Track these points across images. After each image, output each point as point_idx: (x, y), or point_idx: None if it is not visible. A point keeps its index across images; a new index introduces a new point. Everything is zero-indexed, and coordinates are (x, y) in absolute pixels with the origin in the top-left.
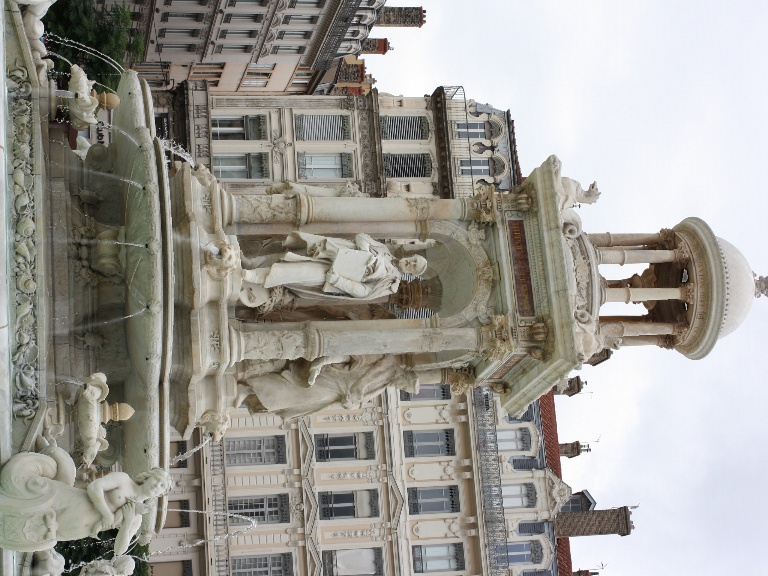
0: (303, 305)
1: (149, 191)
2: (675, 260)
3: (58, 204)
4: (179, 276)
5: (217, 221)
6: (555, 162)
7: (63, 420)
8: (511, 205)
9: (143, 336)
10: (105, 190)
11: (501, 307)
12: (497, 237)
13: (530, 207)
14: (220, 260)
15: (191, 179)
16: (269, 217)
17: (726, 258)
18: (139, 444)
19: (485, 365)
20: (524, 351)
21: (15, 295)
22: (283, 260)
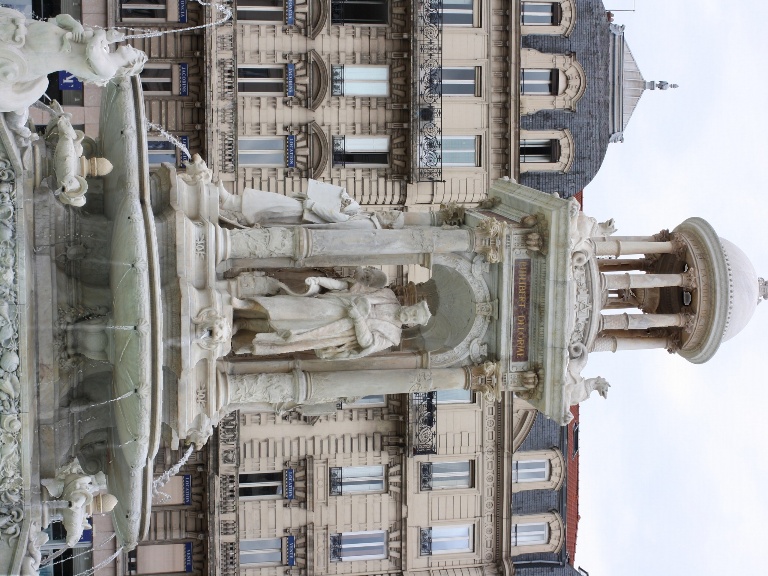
0: None
1: None
2: (656, 239)
3: None
4: None
5: None
6: None
7: (39, 151)
8: None
9: (117, 120)
10: None
11: None
12: (469, 217)
13: (493, 201)
14: (193, 165)
15: None
16: (244, 218)
17: None
18: (123, 229)
19: (500, 322)
20: (522, 246)
21: None
22: None
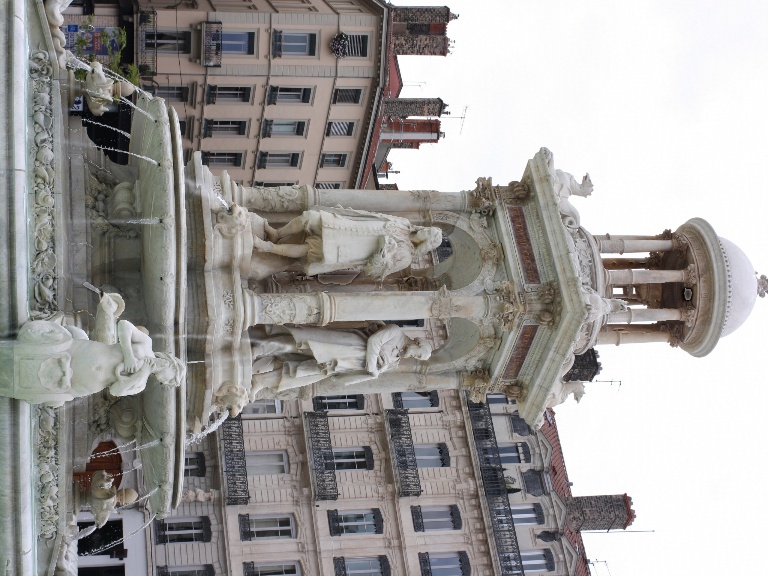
0: None
1: (164, 490)
2: None
3: (80, 410)
4: (190, 406)
5: (236, 341)
6: (588, 319)
7: None
8: (533, 317)
9: None
10: None
11: (490, 362)
12: (508, 331)
13: None
14: None
15: None
16: None
17: None
18: None
19: None
20: None
21: (40, 521)
22: (291, 376)
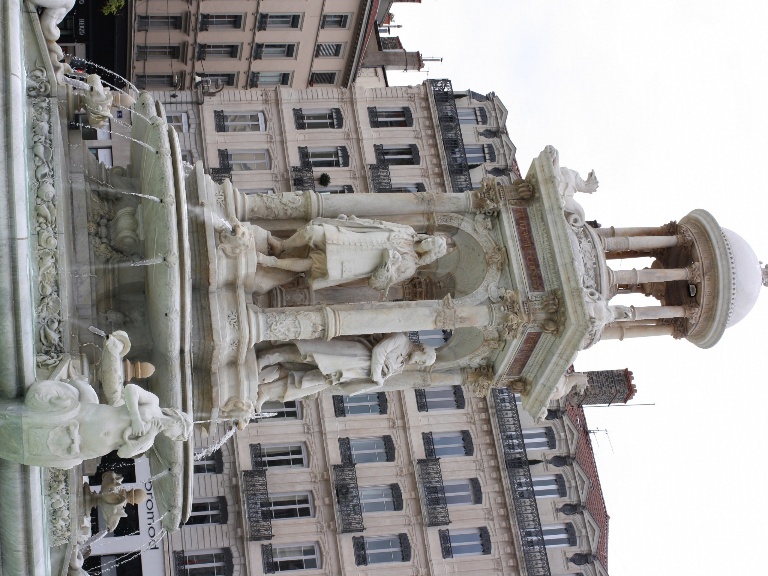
0: None
1: (173, 514)
2: None
3: None
4: (197, 419)
5: (241, 358)
6: (591, 332)
7: None
8: (537, 325)
9: None
10: (134, 353)
11: (494, 360)
12: None
13: None
14: None
15: (221, 345)
16: None
17: (730, 320)
18: None
19: None
20: None
21: None
22: (297, 387)
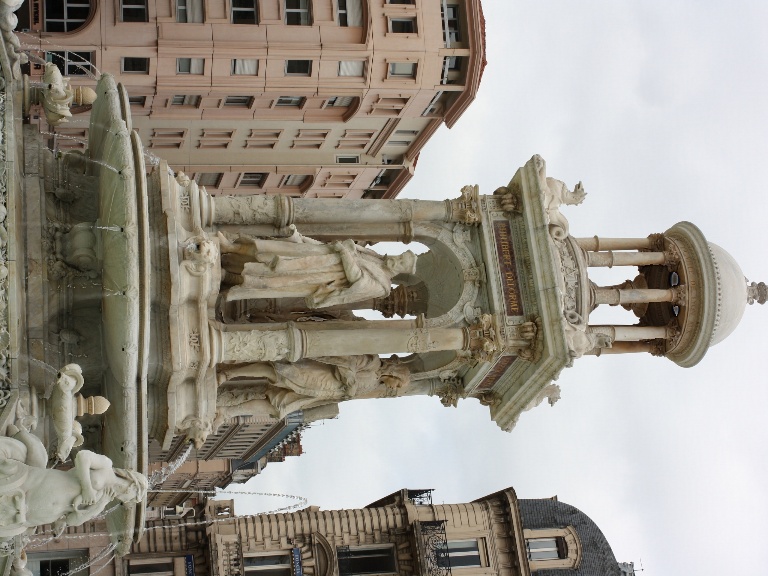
0: (286, 299)
1: None
2: None
3: None
4: None
5: None
6: None
7: None
8: None
9: None
10: None
11: None
12: None
13: None
14: (177, 178)
15: None
16: None
17: None
18: None
19: (489, 281)
20: (498, 209)
21: None
22: None
